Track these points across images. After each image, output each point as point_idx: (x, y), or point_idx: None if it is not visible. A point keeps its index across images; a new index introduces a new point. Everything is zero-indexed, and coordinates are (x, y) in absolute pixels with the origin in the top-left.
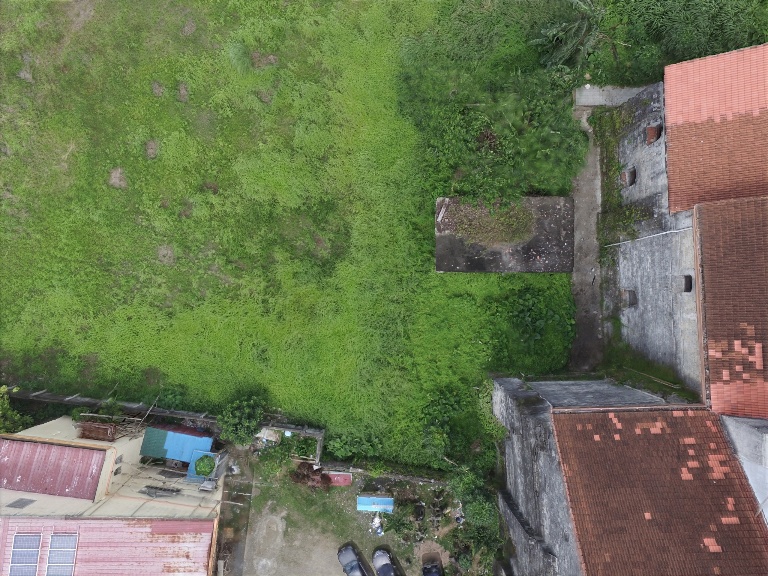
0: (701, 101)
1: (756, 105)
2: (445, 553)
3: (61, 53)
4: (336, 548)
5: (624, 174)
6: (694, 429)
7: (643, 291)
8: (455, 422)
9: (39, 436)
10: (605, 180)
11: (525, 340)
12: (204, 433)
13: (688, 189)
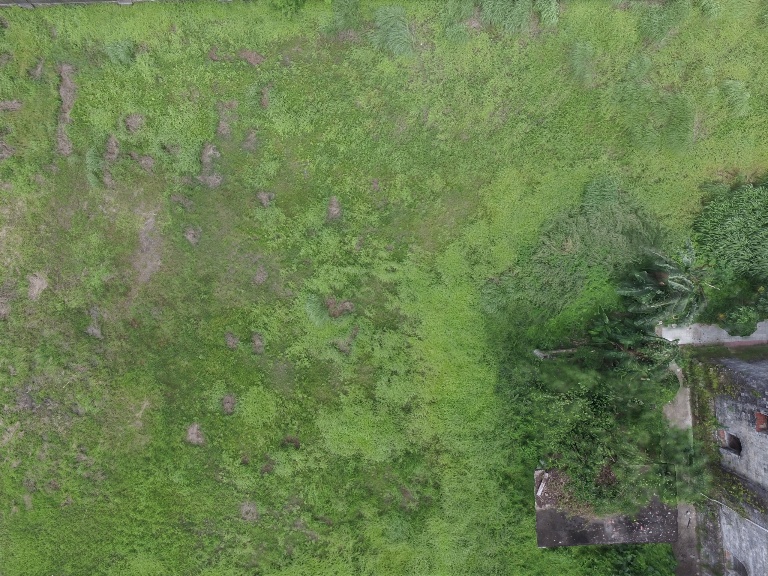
0: None
1: None
2: None
3: (129, 307)
4: None
5: (722, 431)
6: None
7: (757, 575)
8: None
9: None
10: (698, 424)
11: None
12: None
13: None
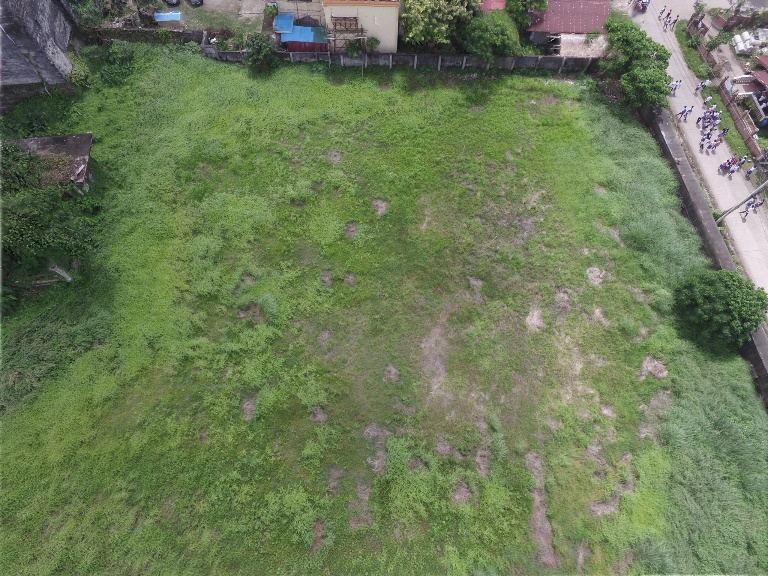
0: None
1: None
2: (129, 6)
3: (446, 305)
4: (205, 5)
5: None
6: None
7: None
8: None
9: (376, 8)
10: None
11: None
12: (293, 50)
13: None
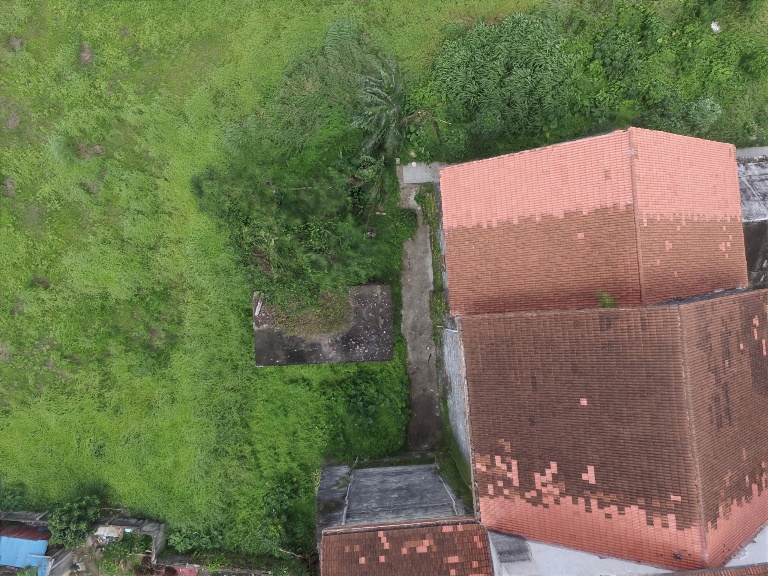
0: (471, 206)
1: (516, 213)
2: None
3: None
4: None
5: None
6: (460, 546)
7: (453, 382)
8: (296, 508)
9: None
10: (434, 258)
11: (360, 424)
12: (44, 533)
13: (465, 293)
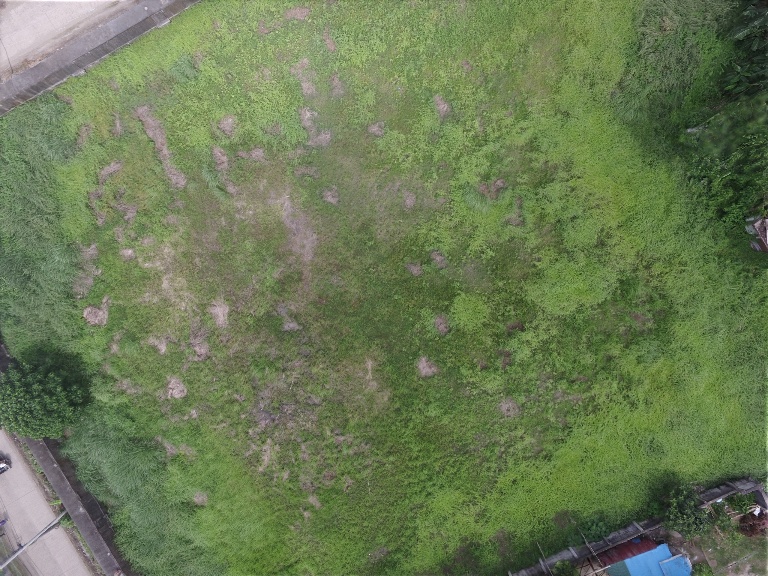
0: None
1: None
2: None
3: (310, 288)
4: None
5: None
6: None
7: None
8: None
9: None
10: None
11: None
12: (645, 542)
13: None
